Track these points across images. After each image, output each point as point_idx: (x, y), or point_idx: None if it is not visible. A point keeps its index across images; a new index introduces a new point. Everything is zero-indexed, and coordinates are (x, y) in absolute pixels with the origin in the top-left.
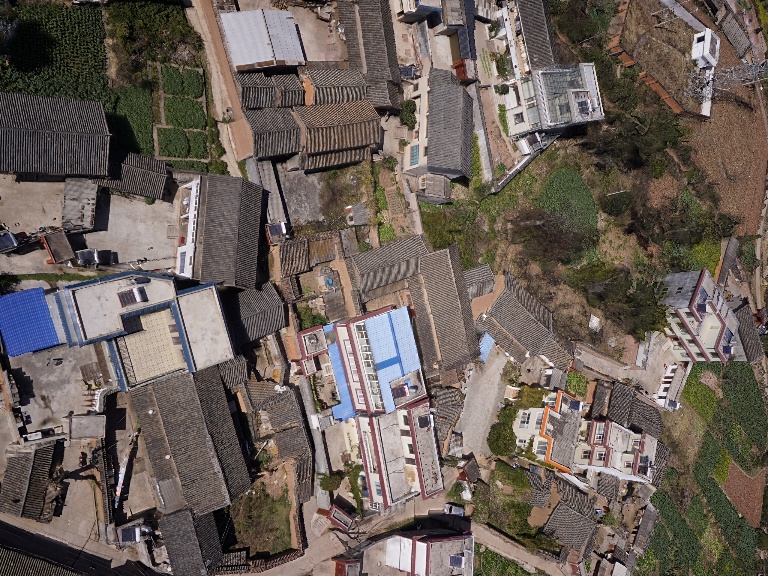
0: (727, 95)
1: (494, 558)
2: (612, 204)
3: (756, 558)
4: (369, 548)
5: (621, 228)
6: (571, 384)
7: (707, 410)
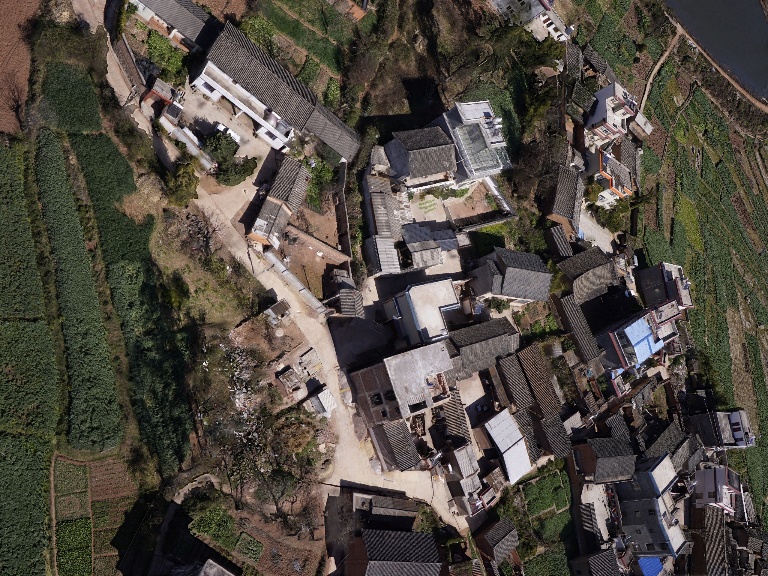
0: None
1: None
2: None
3: None
4: None
5: None
6: None
7: None
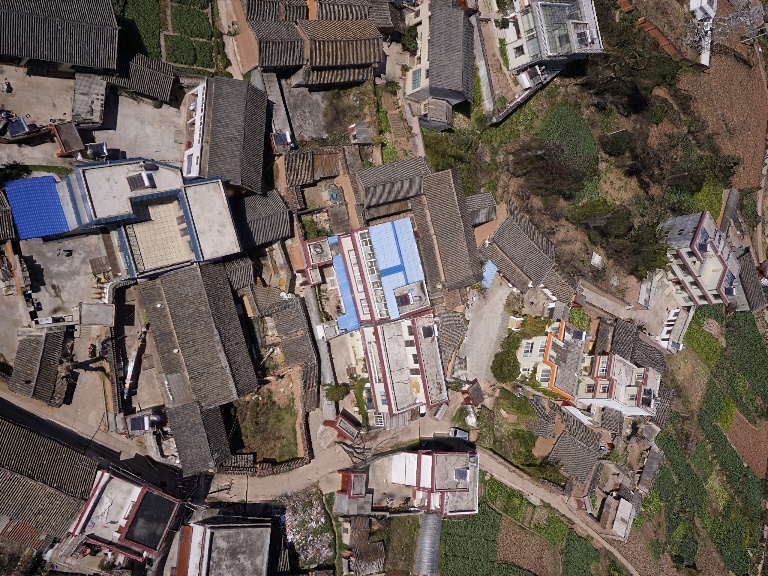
0: (726, 49)
1: (499, 487)
2: (612, 143)
3: (762, 508)
4: (375, 464)
5: (622, 170)
6: (574, 320)
7: (710, 357)
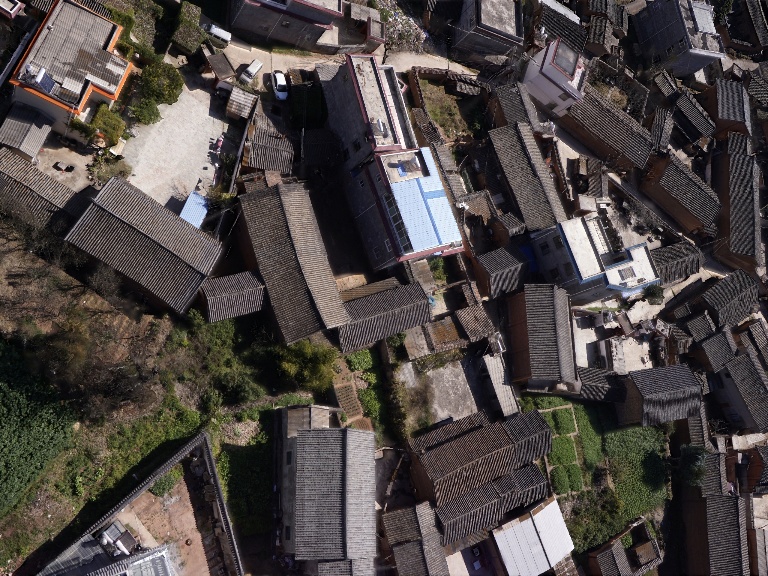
0: None
1: None
2: None
3: None
4: None
5: None
6: None
7: None
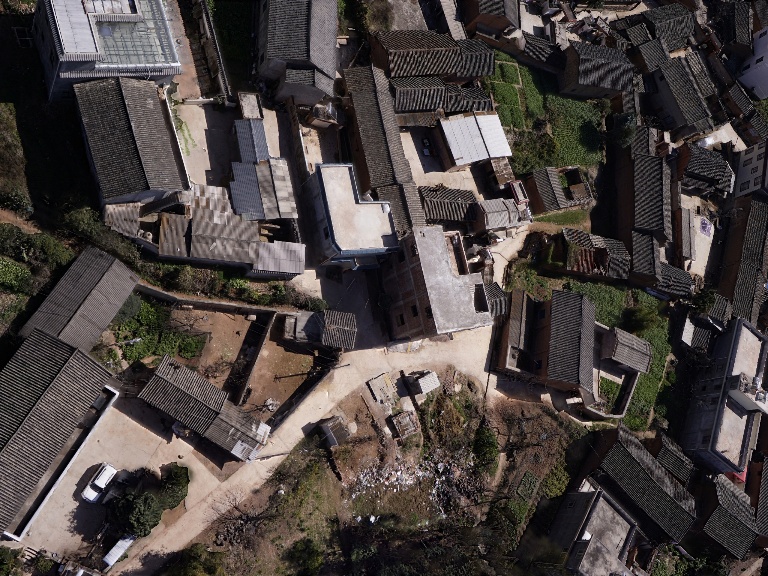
0: None
1: None
2: None
3: None
4: None
5: None
6: None
7: None
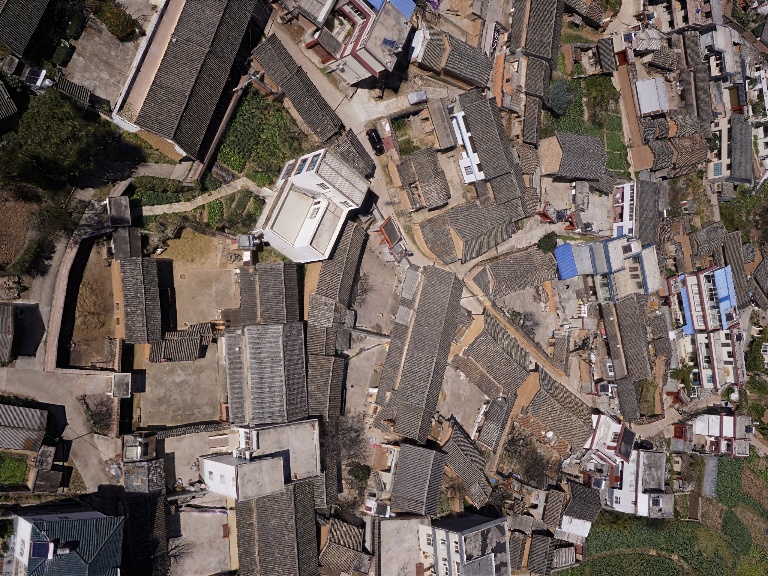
0: None
1: None
2: None
3: None
4: None
5: None
6: None
7: None
